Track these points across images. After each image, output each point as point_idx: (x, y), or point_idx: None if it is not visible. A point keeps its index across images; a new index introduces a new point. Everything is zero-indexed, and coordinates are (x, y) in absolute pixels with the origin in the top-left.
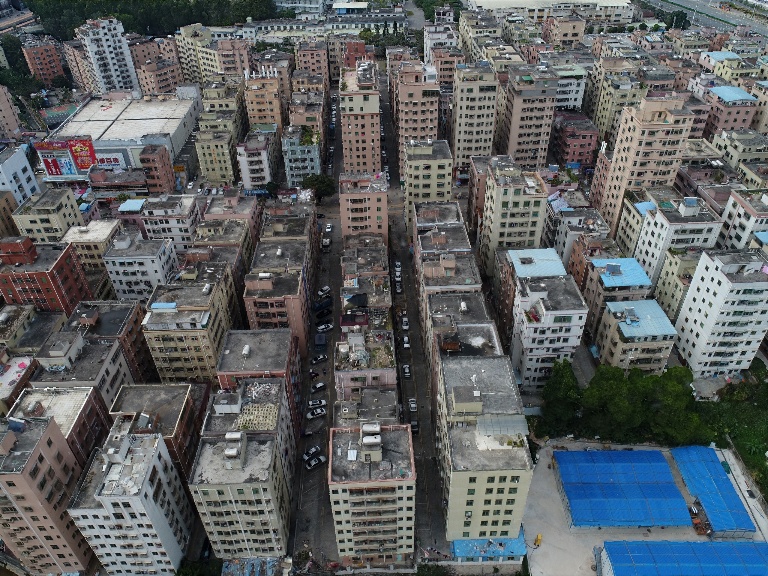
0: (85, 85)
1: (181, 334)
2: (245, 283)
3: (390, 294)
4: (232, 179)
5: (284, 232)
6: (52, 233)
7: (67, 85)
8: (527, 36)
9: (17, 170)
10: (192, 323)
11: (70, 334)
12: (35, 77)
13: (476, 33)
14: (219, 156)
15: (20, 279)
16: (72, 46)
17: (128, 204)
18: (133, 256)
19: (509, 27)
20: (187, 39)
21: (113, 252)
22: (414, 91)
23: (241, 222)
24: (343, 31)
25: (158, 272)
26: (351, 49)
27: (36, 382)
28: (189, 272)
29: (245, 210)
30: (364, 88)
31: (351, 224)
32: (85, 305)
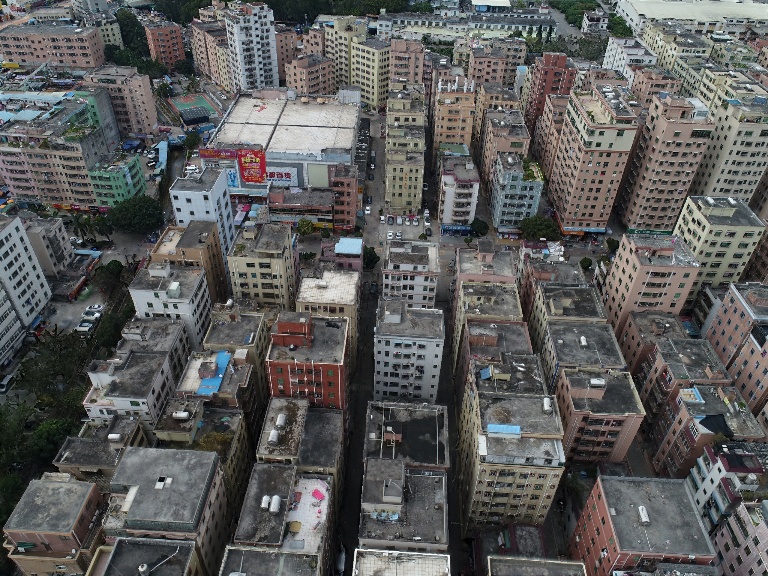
0: (212, 74)
1: (528, 470)
2: (570, 390)
3: (755, 419)
4: (418, 207)
5: (572, 309)
6: (269, 279)
7: (190, 72)
8: (739, 59)
9: (220, 195)
10: (548, 459)
11: (393, 464)
12: (157, 61)
13: (682, 52)
14: (411, 181)
15: (300, 369)
16: (204, 30)
17: (344, 244)
18: (415, 337)
19: (714, 46)
20: (340, 33)
21: (385, 328)
22: (682, 130)
23: (507, 287)
24: (488, 32)
25: (438, 357)
26: (549, 62)
27: (368, 539)
28: (503, 371)
29: (505, 270)
30: (622, 121)
31: (639, 299)
32: (376, 407)
